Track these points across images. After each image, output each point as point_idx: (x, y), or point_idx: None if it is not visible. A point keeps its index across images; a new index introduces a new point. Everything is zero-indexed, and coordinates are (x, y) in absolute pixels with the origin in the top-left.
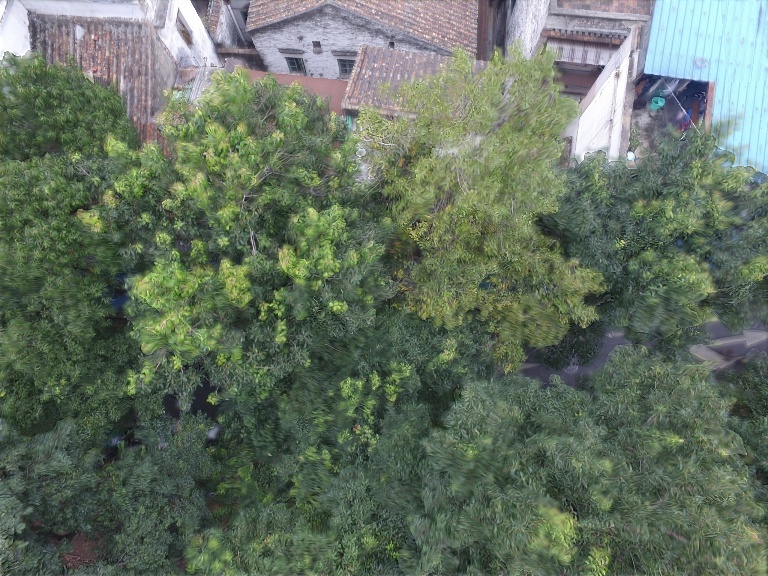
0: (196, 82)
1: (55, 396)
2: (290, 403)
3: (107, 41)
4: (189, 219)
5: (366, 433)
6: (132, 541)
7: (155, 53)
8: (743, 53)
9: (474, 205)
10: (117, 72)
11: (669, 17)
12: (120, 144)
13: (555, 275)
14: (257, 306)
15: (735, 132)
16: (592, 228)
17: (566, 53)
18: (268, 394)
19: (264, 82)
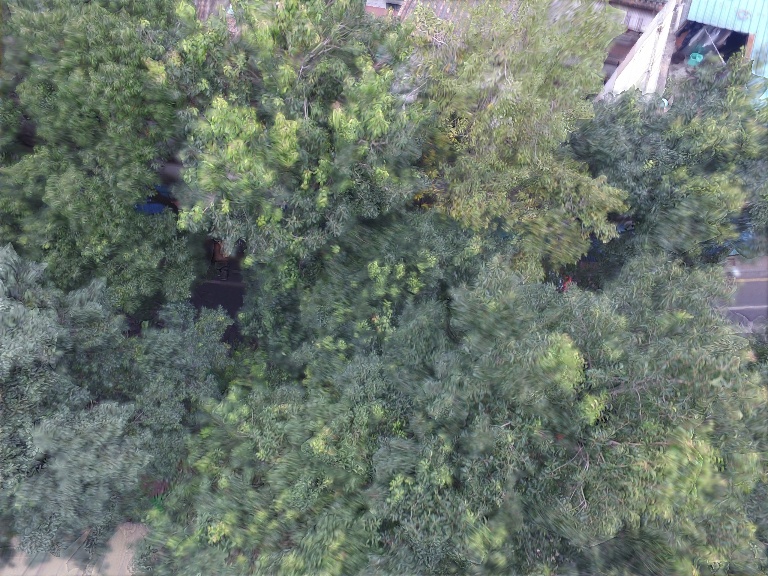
0: None
1: (95, 255)
2: (312, 296)
3: None
4: (244, 94)
5: (384, 323)
6: (150, 402)
7: None
8: None
9: (518, 95)
10: None
11: None
12: None
13: (583, 187)
14: (302, 172)
15: None
16: (623, 150)
17: None
18: (293, 284)
19: None
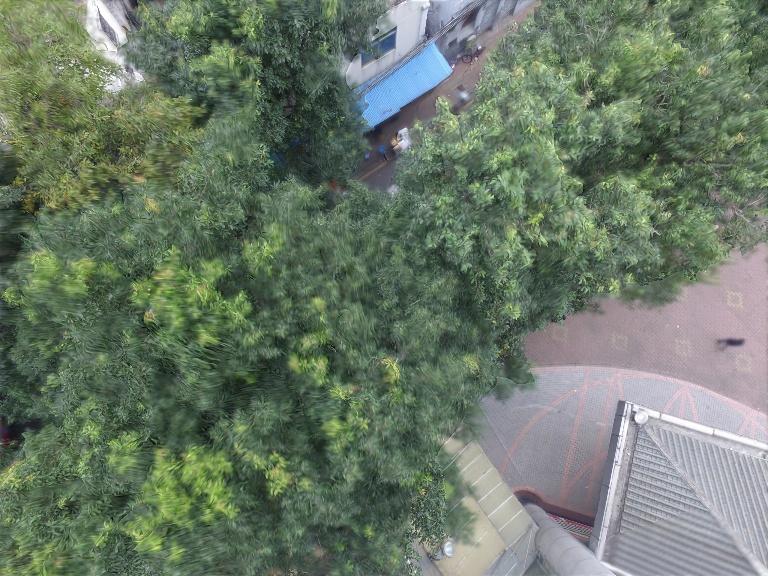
0: None
1: None
2: None
3: None
4: None
5: None
6: None
7: None
8: None
9: None
10: None
11: None
12: None
13: (146, 114)
14: None
15: None
16: (166, 61)
17: None
18: None
19: None
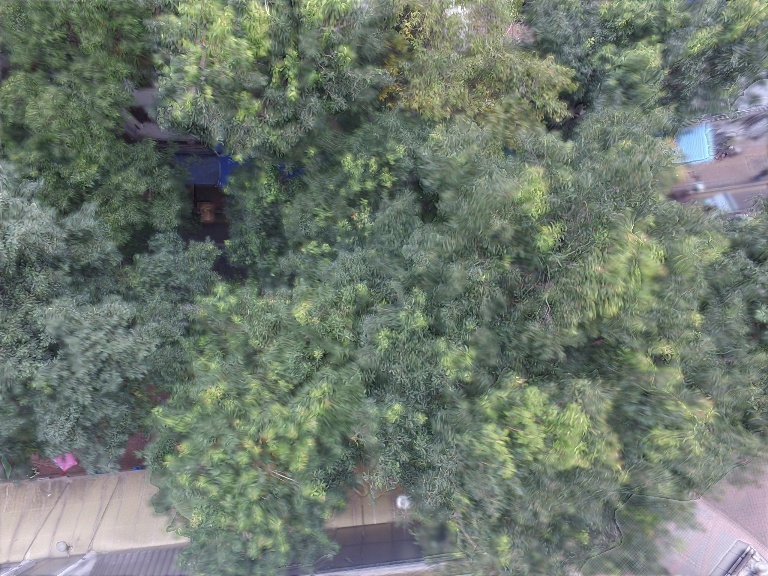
0: None
1: (80, 183)
2: (293, 209)
3: None
4: (206, 8)
5: (363, 219)
6: (150, 318)
7: None
8: None
9: None
10: None
11: None
12: None
13: (533, 69)
14: (269, 69)
15: None
16: (567, 33)
17: None
18: (274, 198)
19: None
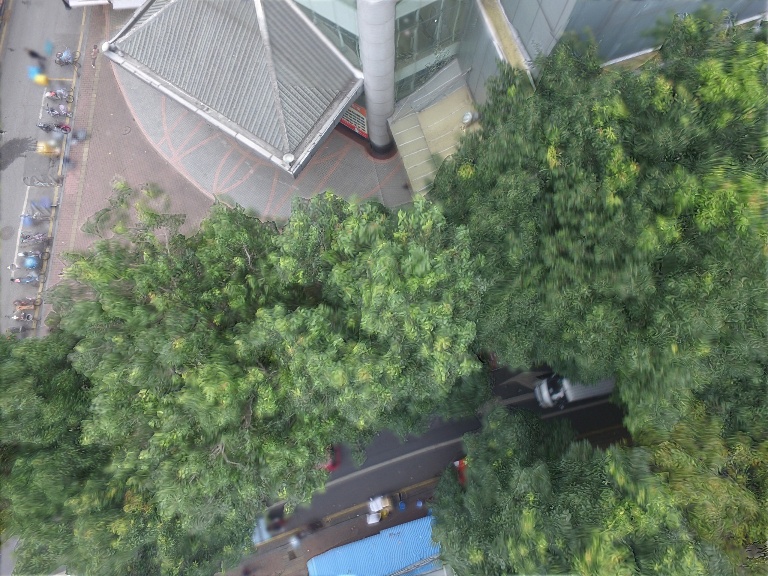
0: None
1: None
2: None
3: None
4: None
5: None
6: None
7: None
8: None
9: None
10: None
11: None
12: None
13: None
14: None
15: None
16: None
17: None
18: None
19: None
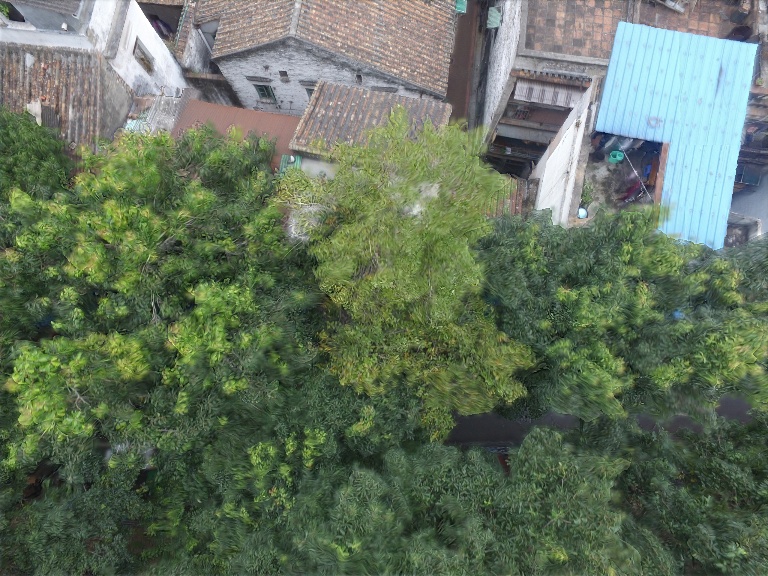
0: (151, 112)
1: None
2: (214, 455)
3: (57, 70)
4: None
5: (281, 497)
6: None
7: (105, 84)
8: (700, 115)
9: (383, 279)
10: (66, 101)
11: (624, 74)
12: (25, 196)
13: (480, 346)
14: (157, 370)
15: (687, 198)
16: (524, 297)
17: (536, 94)
18: (190, 445)
19: (183, 134)
